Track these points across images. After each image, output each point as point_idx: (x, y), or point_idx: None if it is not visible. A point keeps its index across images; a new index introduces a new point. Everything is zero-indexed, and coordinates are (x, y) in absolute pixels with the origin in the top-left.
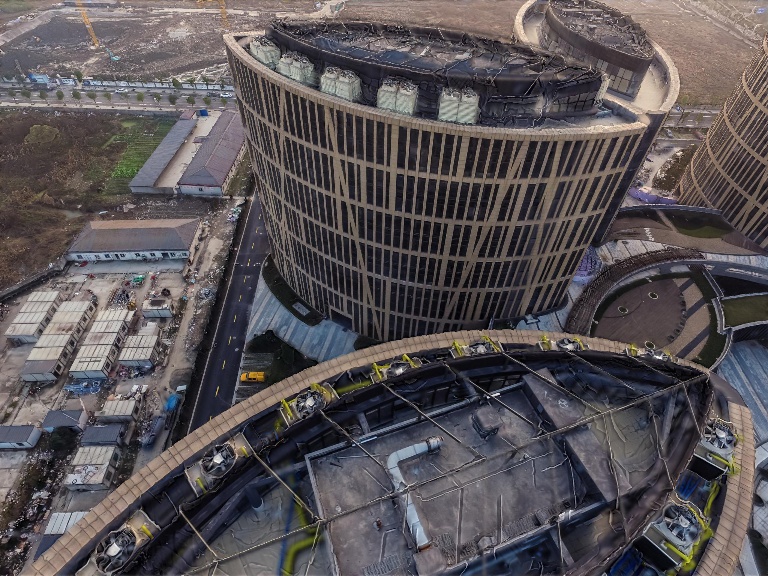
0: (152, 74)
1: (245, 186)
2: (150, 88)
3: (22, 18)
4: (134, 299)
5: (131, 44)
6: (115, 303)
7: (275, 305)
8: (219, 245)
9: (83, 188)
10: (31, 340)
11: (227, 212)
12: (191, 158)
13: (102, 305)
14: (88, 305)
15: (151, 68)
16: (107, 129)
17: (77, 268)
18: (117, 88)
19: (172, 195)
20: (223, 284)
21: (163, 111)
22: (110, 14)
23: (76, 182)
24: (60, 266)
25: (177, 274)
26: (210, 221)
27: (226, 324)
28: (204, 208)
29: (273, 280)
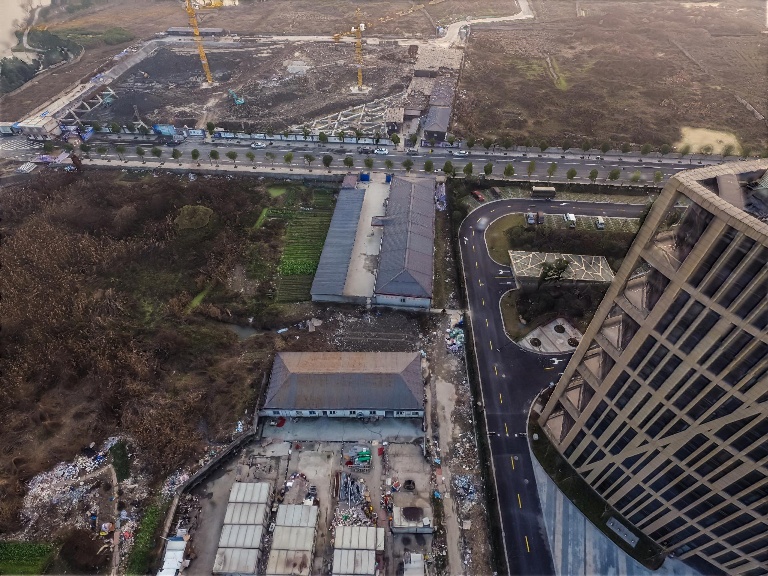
0: (284, 121)
1: (453, 292)
2: (289, 141)
3: (128, 51)
4: (367, 494)
5: (250, 81)
6: (342, 500)
7: (578, 519)
8: (451, 393)
9: (250, 291)
10: (246, 575)
11: (443, 335)
12: (369, 245)
13: (325, 503)
14: (316, 514)
15: (280, 113)
16: (255, 200)
17: (274, 429)
18: (252, 141)
19: (364, 305)
20: (488, 474)
21: (316, 175)
22: (216, 44)
23: (239, 281)
24: (254, 429)
25: (412, 446)
26: (426, 350)
27: (518, 556)
28: (411, 328)
29: (556, 468)
